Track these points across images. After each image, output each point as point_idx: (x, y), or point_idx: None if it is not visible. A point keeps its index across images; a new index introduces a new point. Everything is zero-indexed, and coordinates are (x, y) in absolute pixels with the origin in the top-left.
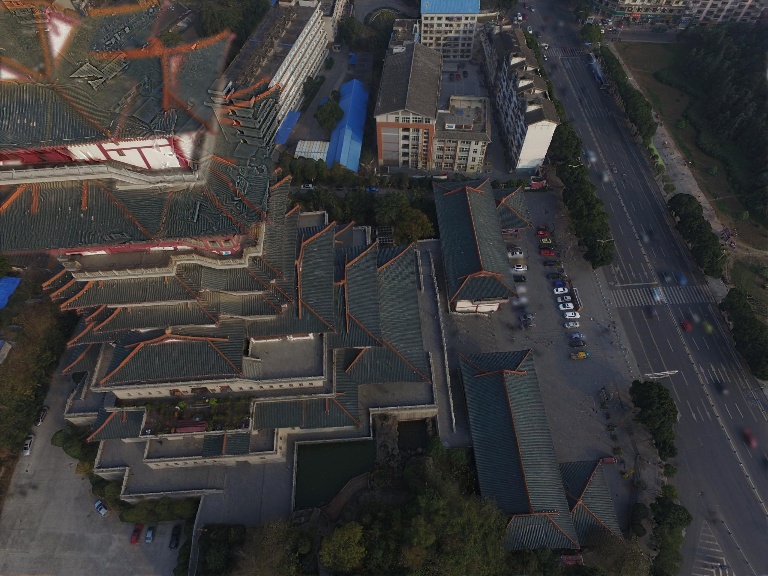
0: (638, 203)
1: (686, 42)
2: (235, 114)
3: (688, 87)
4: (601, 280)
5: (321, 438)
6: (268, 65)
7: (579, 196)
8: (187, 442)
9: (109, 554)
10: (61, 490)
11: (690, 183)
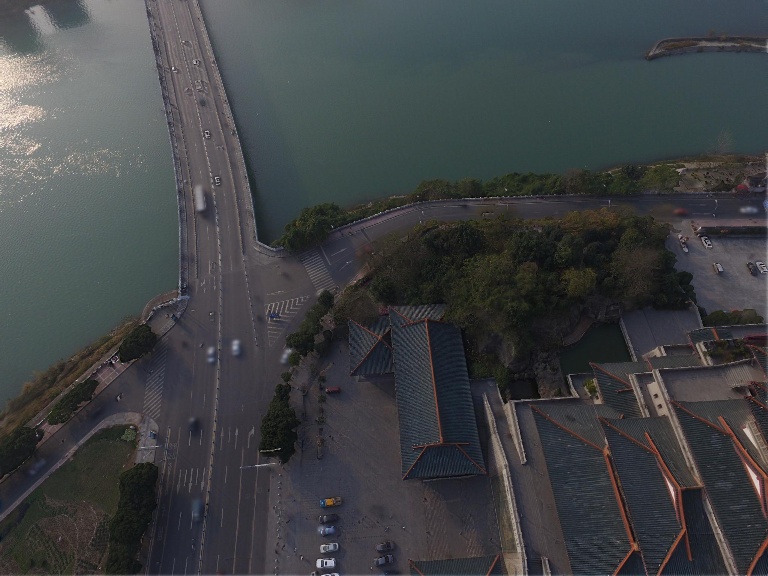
0: None
1: None
2: None
3: None
4: None
5: None
6: None
7: None
8: None
9: (750, 305)
10: None
11: None
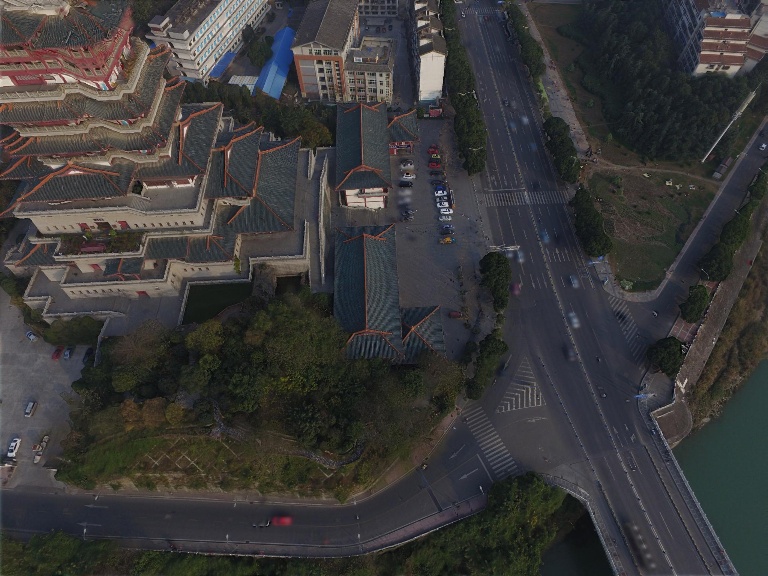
0: (521, 129)
1: (590, 3)
2: (173, 47)
3: (583, 38)
4: (477, 186)
5: (209, 279)
6: (205, 8)
7: (463, 117)
8: (97, 274)
9: (34, 367)
10: (0, 324)
11: (569, 114)
